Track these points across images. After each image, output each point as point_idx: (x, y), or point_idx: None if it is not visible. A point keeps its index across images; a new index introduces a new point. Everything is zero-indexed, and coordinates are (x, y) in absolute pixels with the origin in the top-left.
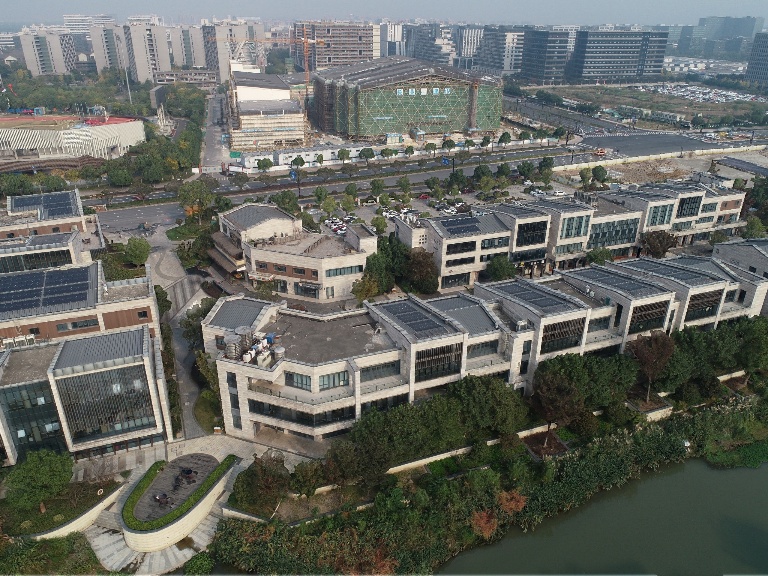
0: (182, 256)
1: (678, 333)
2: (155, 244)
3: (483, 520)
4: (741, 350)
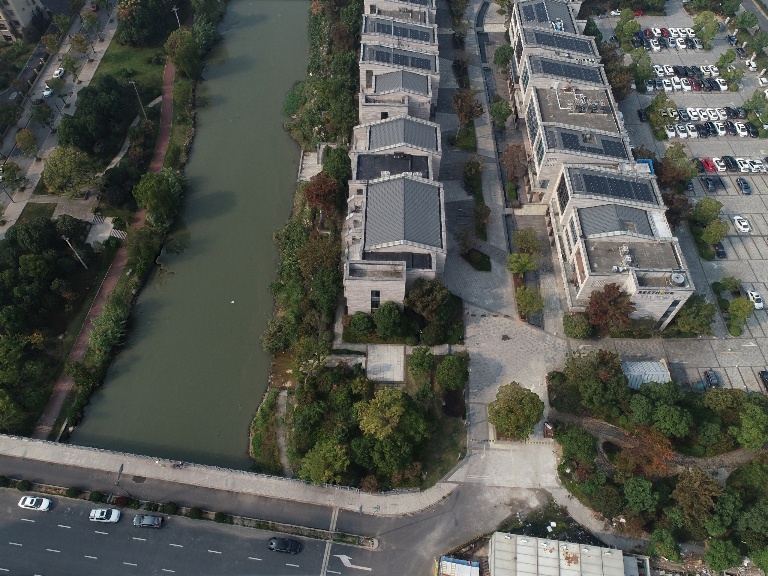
0: None
1: None
2: None
3: (316, 4)
4: None
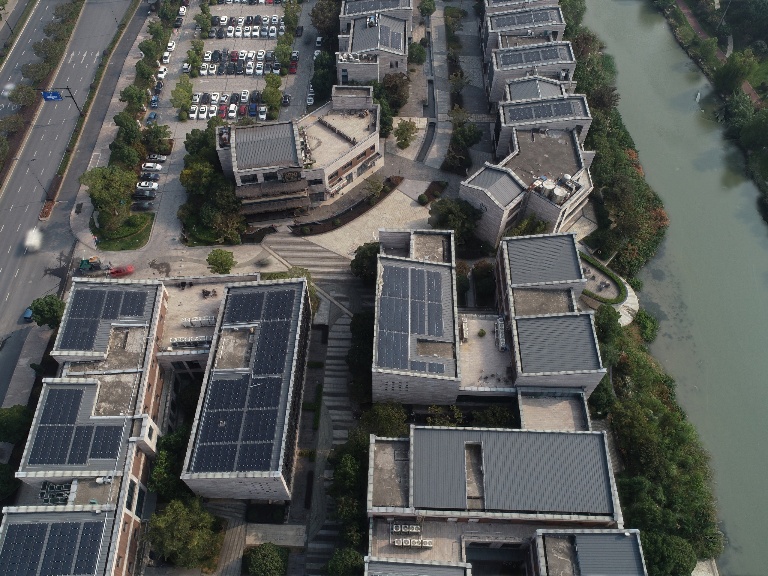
0: (211, 241)
1: (567, 29)
2: (142, 263)
3: None
4: (573, 20)
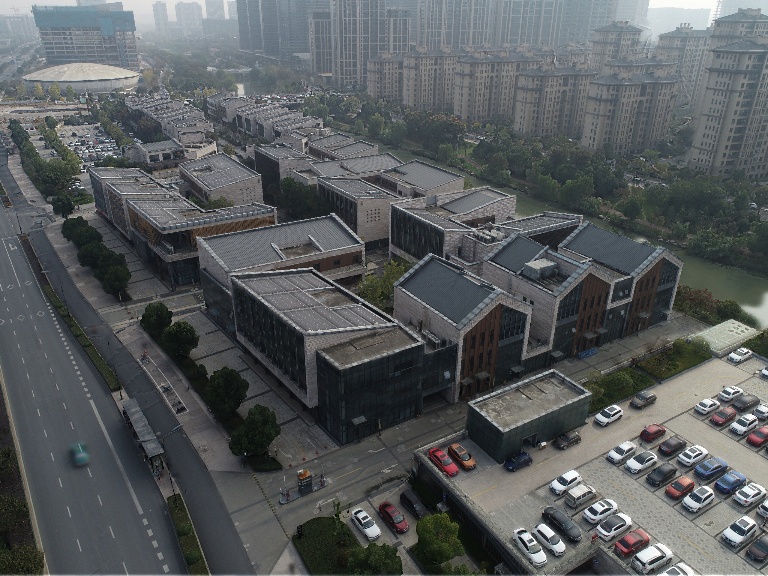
0: None
1: None
2: None
3: None
4: None
